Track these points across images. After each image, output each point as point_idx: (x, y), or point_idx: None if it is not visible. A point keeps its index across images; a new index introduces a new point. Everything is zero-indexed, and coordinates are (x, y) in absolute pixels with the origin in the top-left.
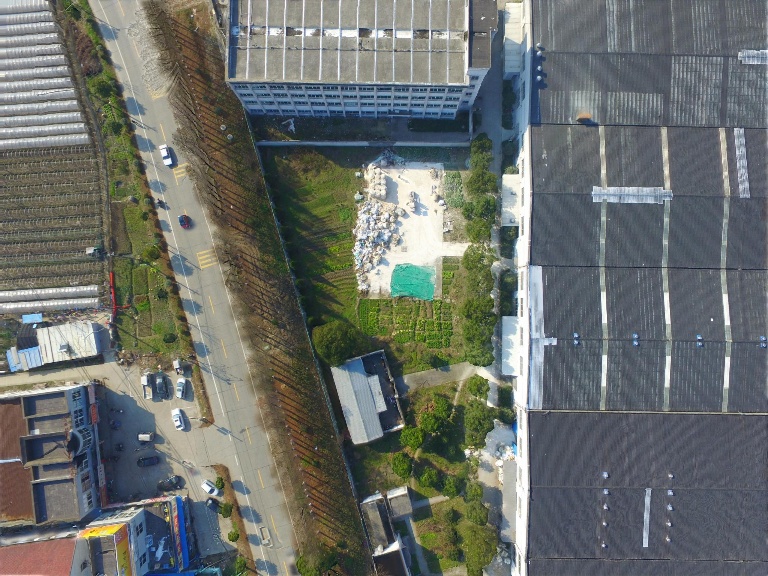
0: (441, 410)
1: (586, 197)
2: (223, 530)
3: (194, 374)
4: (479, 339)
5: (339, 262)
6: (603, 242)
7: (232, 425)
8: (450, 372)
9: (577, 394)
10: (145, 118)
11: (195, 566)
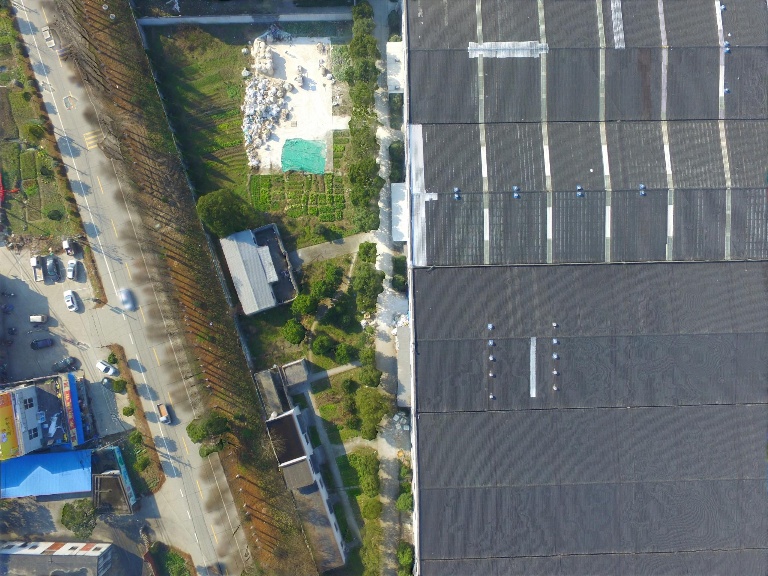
0: (329, 274)
1: (462, 53)
2: (121, 410)
3: (85, 255)
4: (362, 200)
5: (229, 139)
6: (482, 98)
7: (125, 304)
8: (344, 245)
9: (460, 249)
10: (26, 1)
11: (93, 446)
